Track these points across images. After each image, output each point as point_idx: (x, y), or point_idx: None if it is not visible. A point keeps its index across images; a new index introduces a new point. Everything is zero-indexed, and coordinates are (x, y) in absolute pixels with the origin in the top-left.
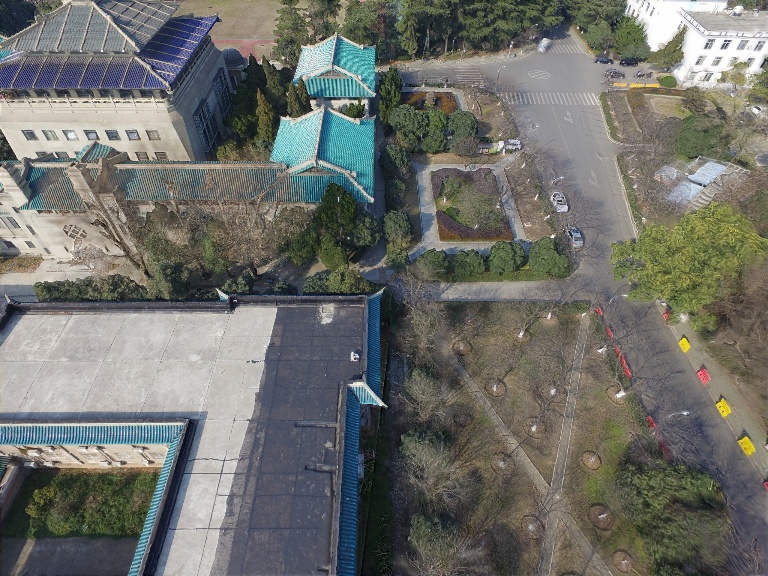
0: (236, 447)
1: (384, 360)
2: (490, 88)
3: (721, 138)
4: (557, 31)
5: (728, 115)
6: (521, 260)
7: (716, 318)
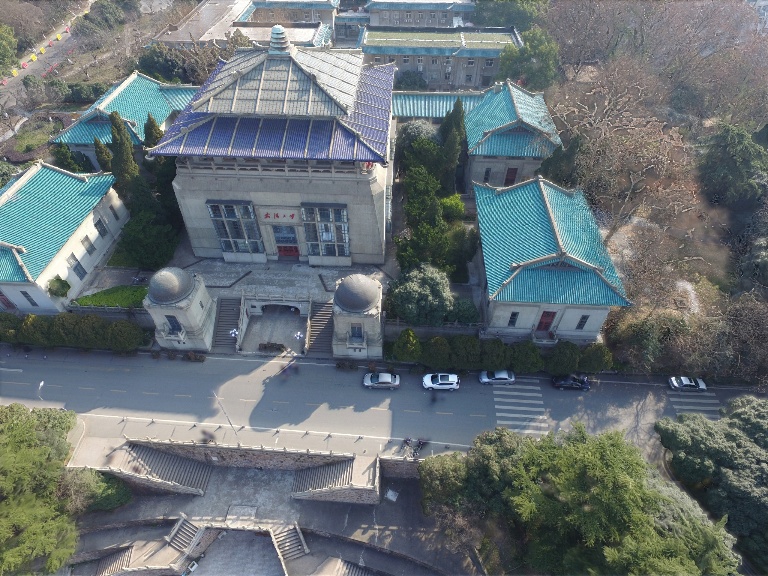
0: None
1: None
2: None
3: None
4: None
5: None
6: None
7: None
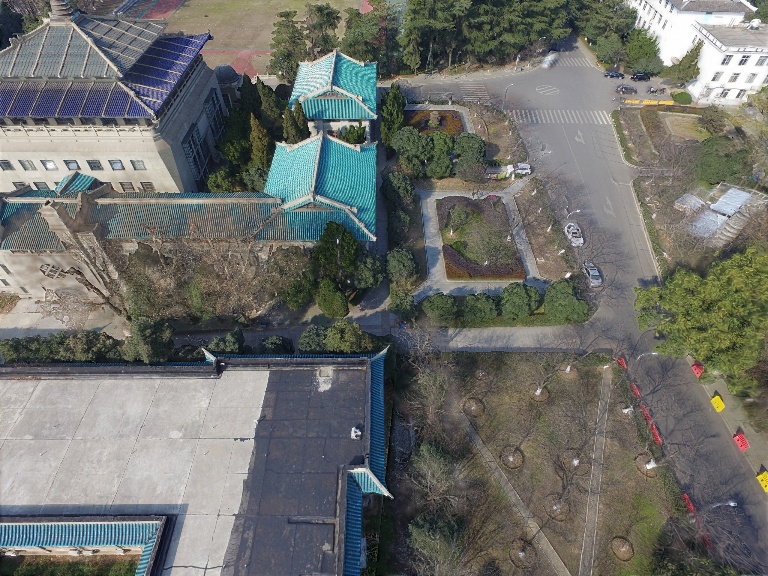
0: (220, 551)
1: (388, 421)
2: (497, 105)
3: (746, 165)
4: (564, 43)
5: (748, 135)
6: (536, 305)
7: (759, 383)
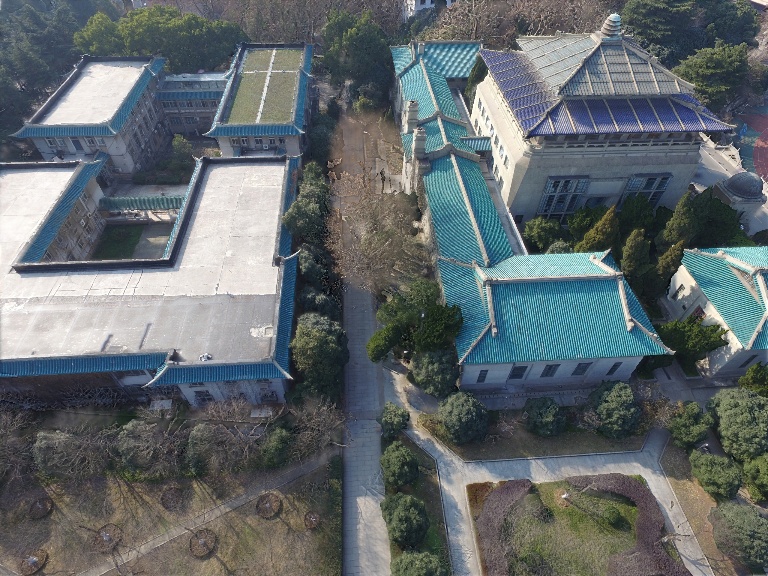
0: (143, 292)
1: None
2: None
3: None
4: None
5: None
6: None
7: None
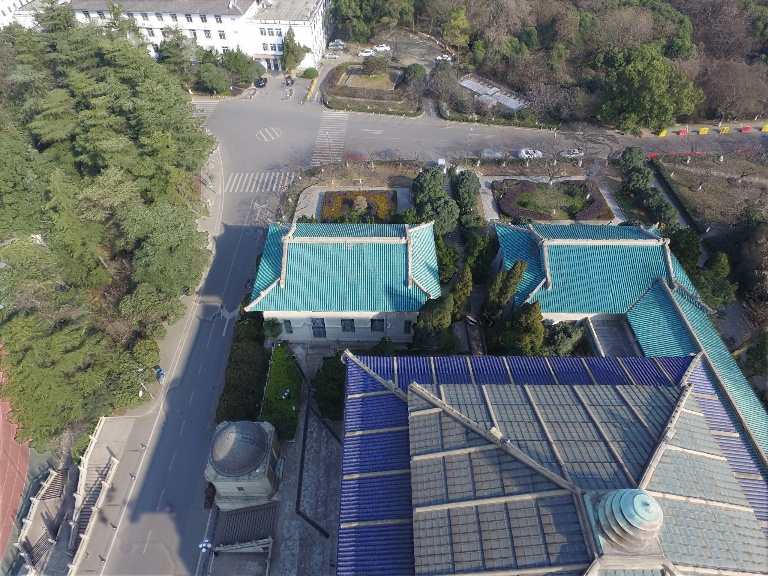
0: None
1: None
2: None
3: None
4: None
5: None
6: None
7: None
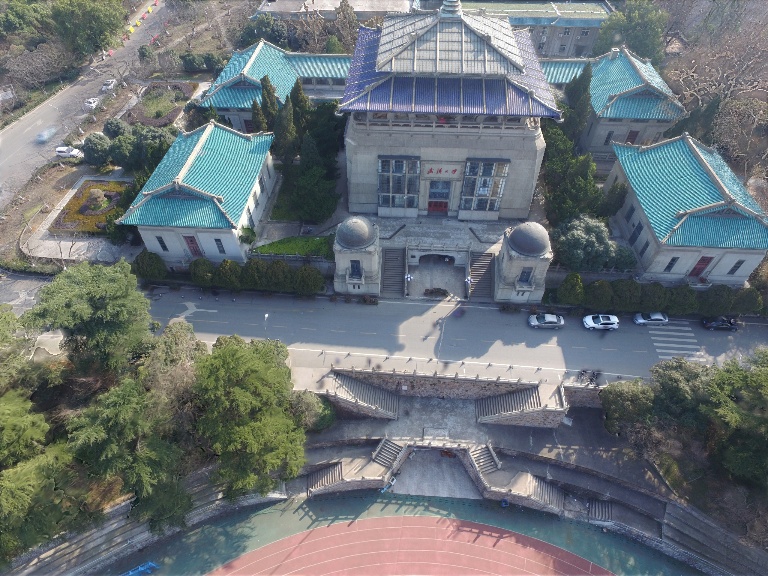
0: None
1: None
2: None
3: None
4: None
5: None
6: None
7: None
